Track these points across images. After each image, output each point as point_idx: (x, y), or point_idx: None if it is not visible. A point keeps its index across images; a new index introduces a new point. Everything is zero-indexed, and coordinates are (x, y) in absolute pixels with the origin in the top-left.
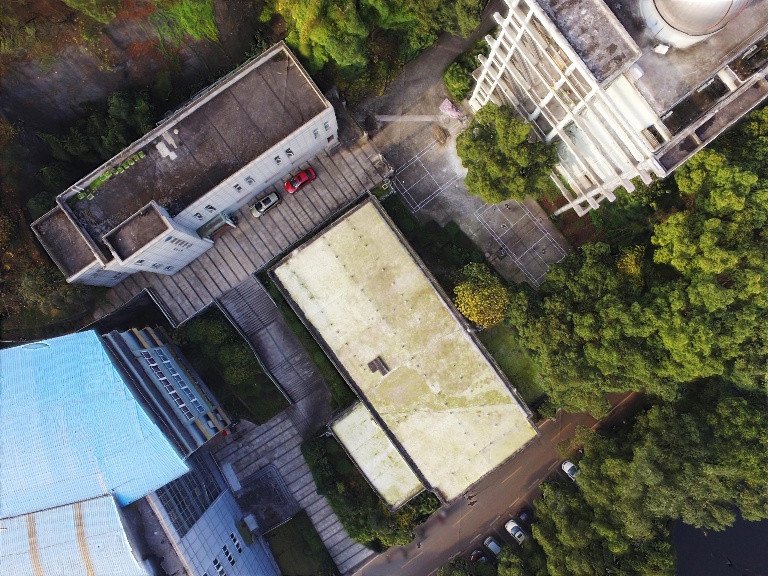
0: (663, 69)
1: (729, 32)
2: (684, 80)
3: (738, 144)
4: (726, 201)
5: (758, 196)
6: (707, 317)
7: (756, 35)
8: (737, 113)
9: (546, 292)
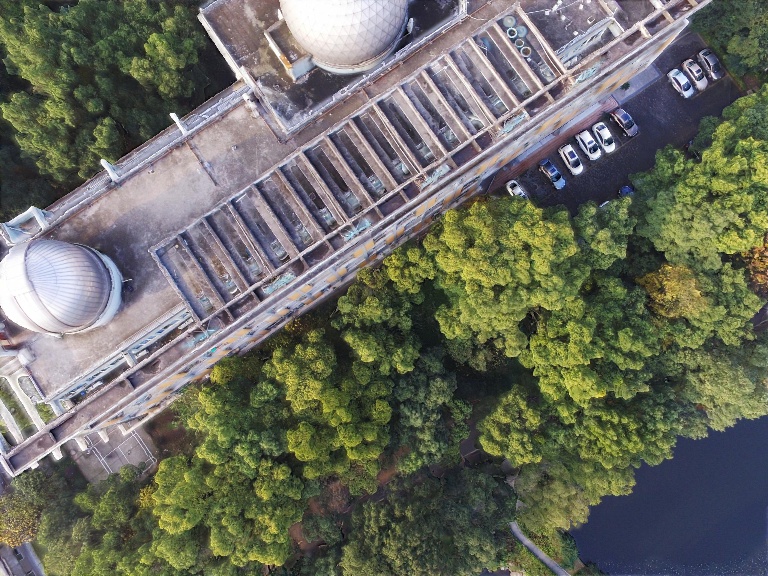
0: (59, 353)
1: (129, 318)
2: (79, 365)
3: (257, 382)
4: (201, 456)
5: (238, 451)
6: (175, 575)
7: (155, 322)
8: (98, 413)
9: (84, 511)
